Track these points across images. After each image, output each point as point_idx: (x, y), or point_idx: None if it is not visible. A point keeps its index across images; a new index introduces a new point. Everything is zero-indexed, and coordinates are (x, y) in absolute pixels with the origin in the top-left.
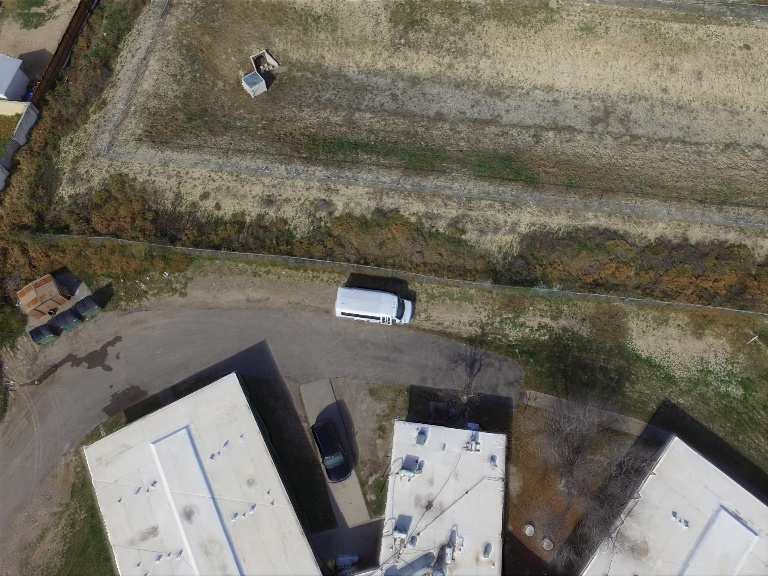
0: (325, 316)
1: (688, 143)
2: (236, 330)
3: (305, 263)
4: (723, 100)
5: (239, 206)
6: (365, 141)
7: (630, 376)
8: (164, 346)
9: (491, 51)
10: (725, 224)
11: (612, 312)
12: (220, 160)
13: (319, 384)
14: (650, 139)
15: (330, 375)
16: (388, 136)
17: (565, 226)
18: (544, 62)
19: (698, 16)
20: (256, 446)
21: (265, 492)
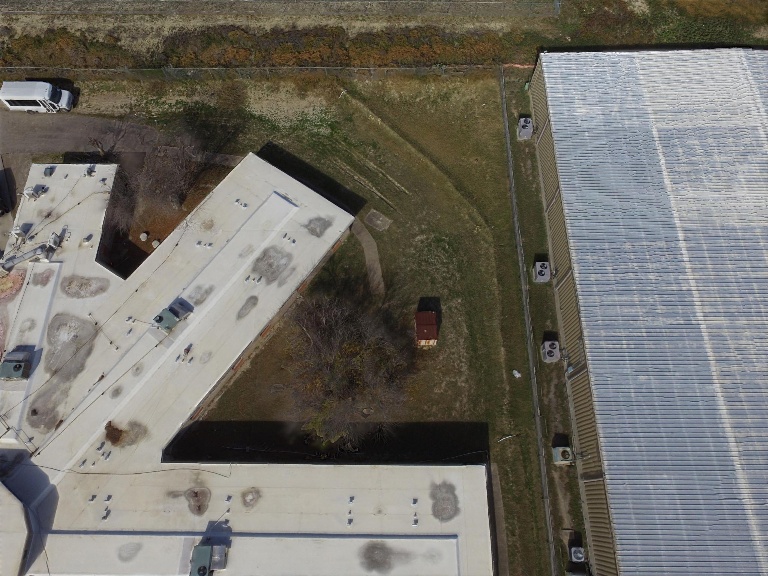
0: (4, 113)
1: None
2: None
3: None
4: None
5: None
6: None
7: (243, 129)
8: None
9: None
10: (328, 14)
11: (234, 86)
12: None
13: None
14: None
15: (2, 152)
16: None
17: (199, 27)
18: None
19: None
20: None
21: None
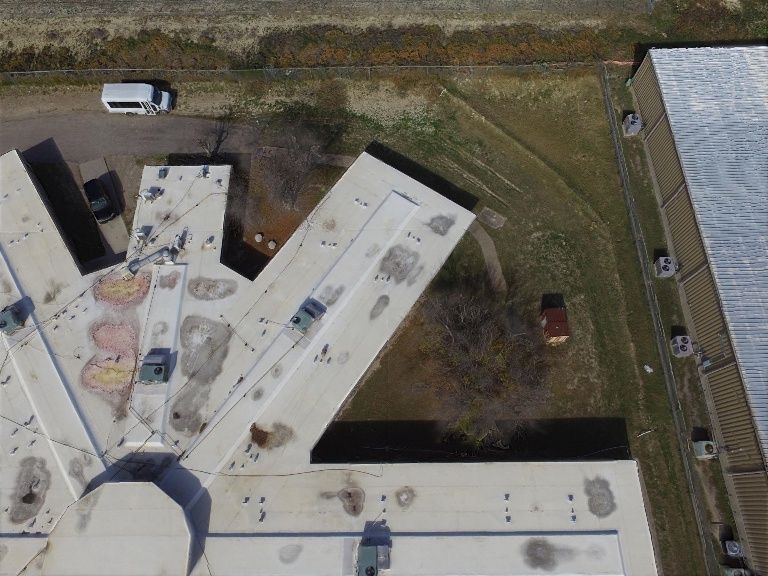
0: (102, 116)
1: None
2: (28, 133)
3: (83, 76)
4: None
5: (28, 42)
6: None
7: (347, 129)
8: None
9: None
10: (422, 12)
11: (334, 86)
12: (12, 10)
13: (95, 162)
14: None
15: (104, 155)
16: None
17: (294, 26)
18: None
19: None
20: (30, 196)
21: (36, 224)
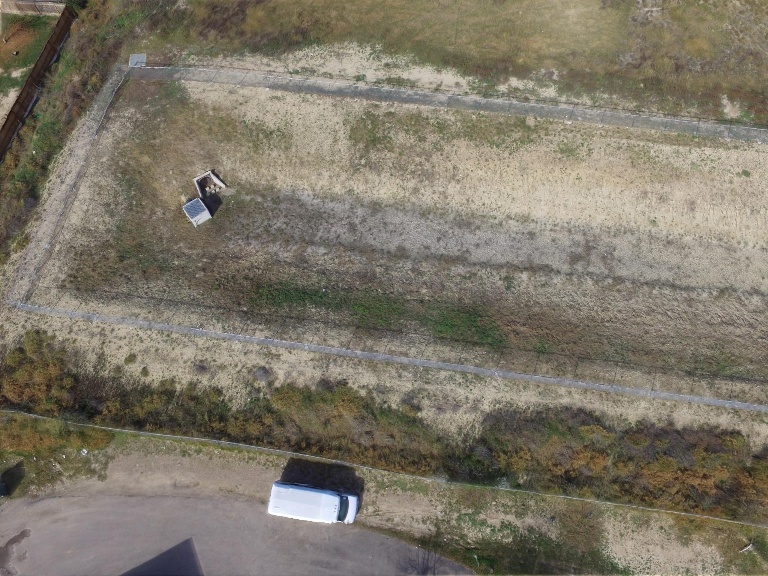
0: (260, 508)
1: (678, 288)
2: (159, 525)
3: (239, 445)
4: (718, 235)
5: (169, 372)
6: (315, 287)
7: None
8: (77, 544)
9: (461, 174)
10: (717, 404)
11: (586, 510)
12: (150, 315)
13: None
14: (635, 283)
15: None
16: (342, 280)
17: (534, 405)
18: (519, 188)
19: (692, 137)
20: None
21: None
